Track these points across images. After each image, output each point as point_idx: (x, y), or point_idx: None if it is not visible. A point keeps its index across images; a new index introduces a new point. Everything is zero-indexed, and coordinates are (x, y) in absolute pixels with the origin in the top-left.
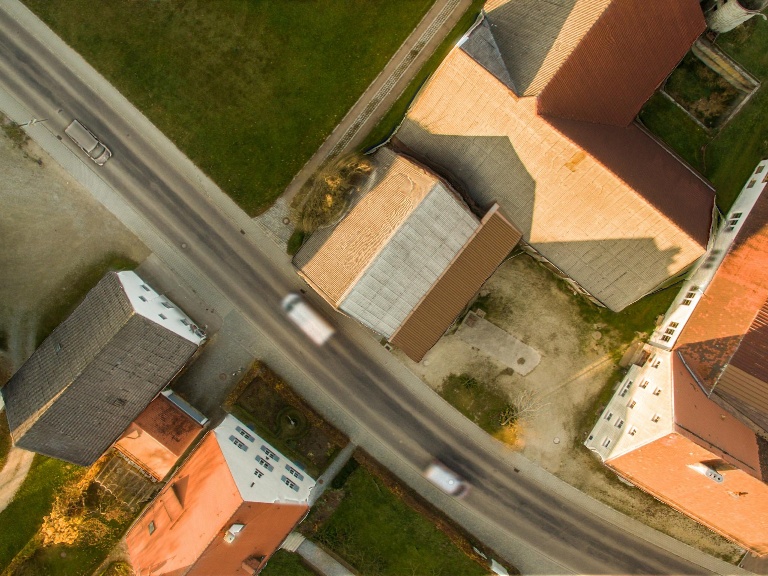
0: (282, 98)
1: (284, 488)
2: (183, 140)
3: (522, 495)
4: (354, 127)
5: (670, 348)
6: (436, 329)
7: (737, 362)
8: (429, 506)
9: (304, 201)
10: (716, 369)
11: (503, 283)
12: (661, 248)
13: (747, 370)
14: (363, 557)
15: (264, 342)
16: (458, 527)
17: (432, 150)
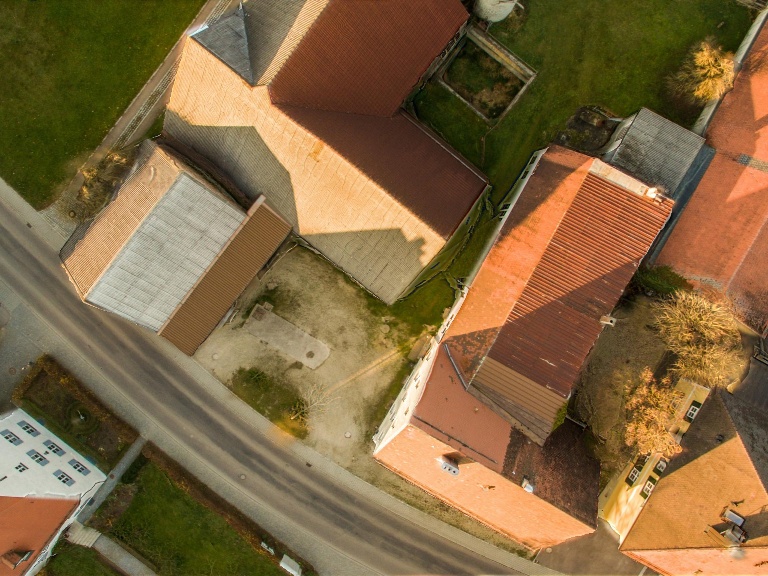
0: (64, 90)
1: (51, 482)
2: None
3: (315, 490)
4: (137, 119)
5: (439, 341)
6: (207, 322)
7: (494, 354)
8: (220, 501)
9: None
10: (475, 361)
11: (290, 276)
12: (408, 239)
13: (504, 362)
14: (160, 553)
15: (52, 336)
16: (250, 522)
17: (196, 141)
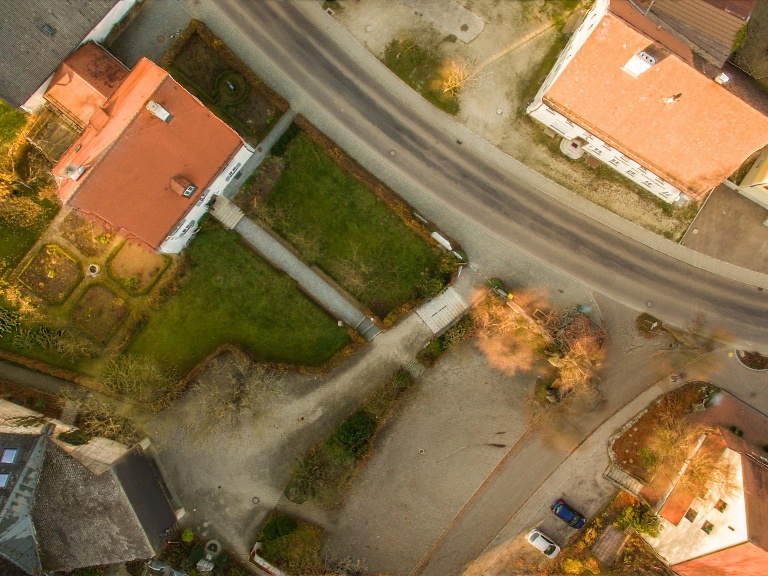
0: None
1: None
2: None
3: (464, 168)
4: None
5: None
6: None
7: None
8: (370, 176)
9: None
10: None
11: None
12: None
13: None
14: (303, 237)
15: (203, 3)
16: (399, 198)
17: None
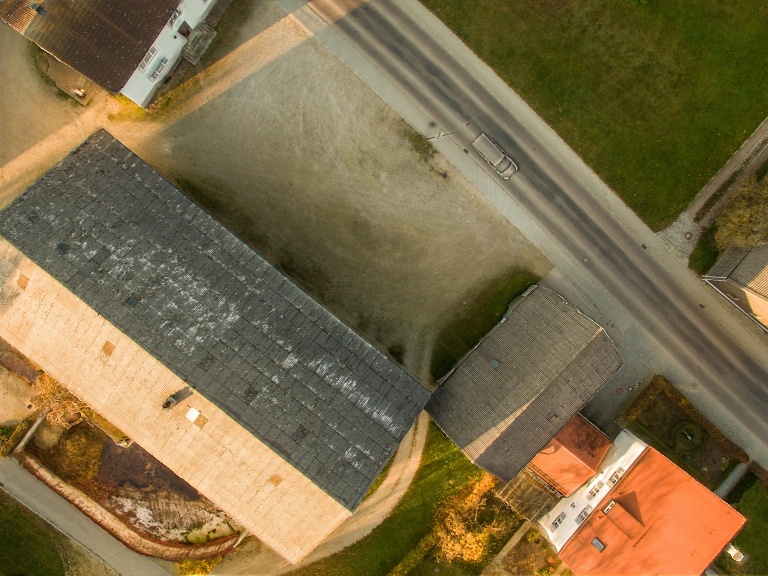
0: (692, 113)
1: None
2: (590, 154)
3: None
4: (762, 143)
5: None
6: None
7: None
8: None
9: (707, 216)
10: None
11: None
12: None
13: None
14: (746, 572)
15: (662, 357)
16: None
17: None
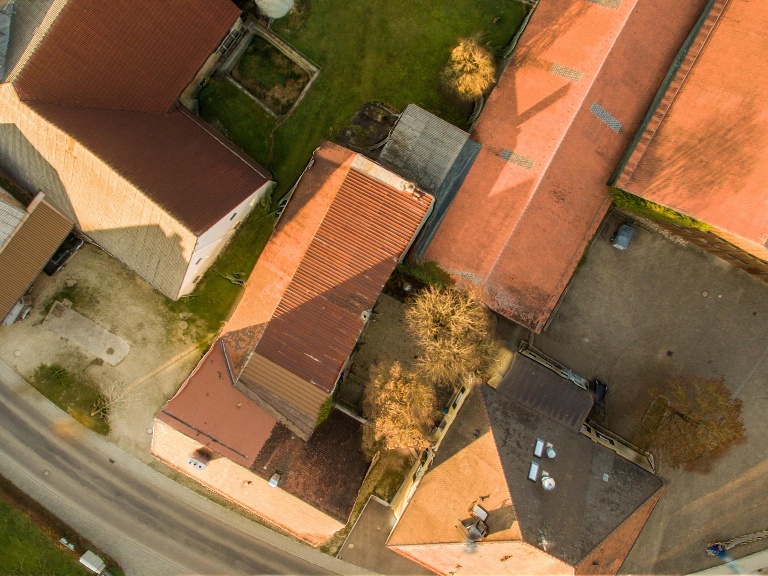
0: None
1: None
2: None
3: (118, 486)
4: None
5: None
6: None
7: (261, 350)
8: (24, 497)
9: None
10: (244, 357)
11: (89, 273)
12: (166, 235)
13: (271, 358)
14: None
15: None
16: (54, 518)
17: None
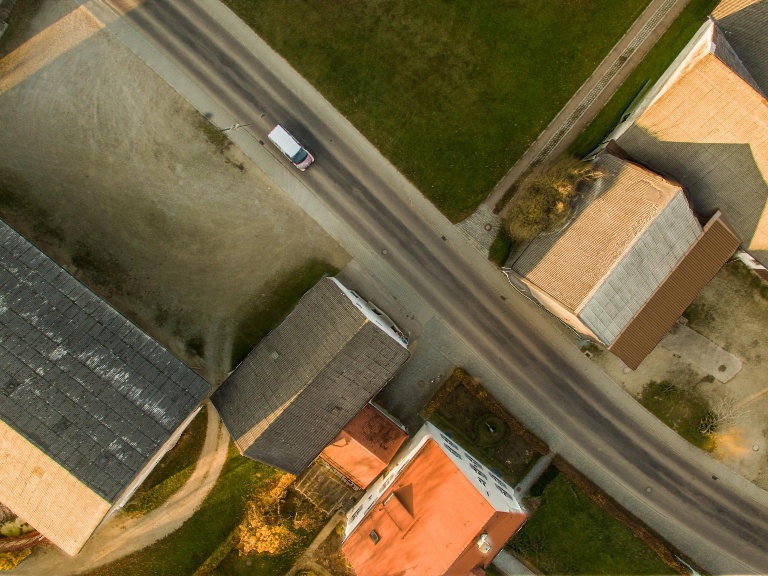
0: (488, 104)
1: (504, 497)
2: (387, 146)
3: (720, 503)
4: (560, 133)
5: None
6: (654, 336)
7: None
8: (627, 514)
9: (507, 207)
10: None
11: (706, 290)
12: None
13: None
14: (555, 565)
15: (464, 349)
16: (656, 535)
17: (656, 157)
